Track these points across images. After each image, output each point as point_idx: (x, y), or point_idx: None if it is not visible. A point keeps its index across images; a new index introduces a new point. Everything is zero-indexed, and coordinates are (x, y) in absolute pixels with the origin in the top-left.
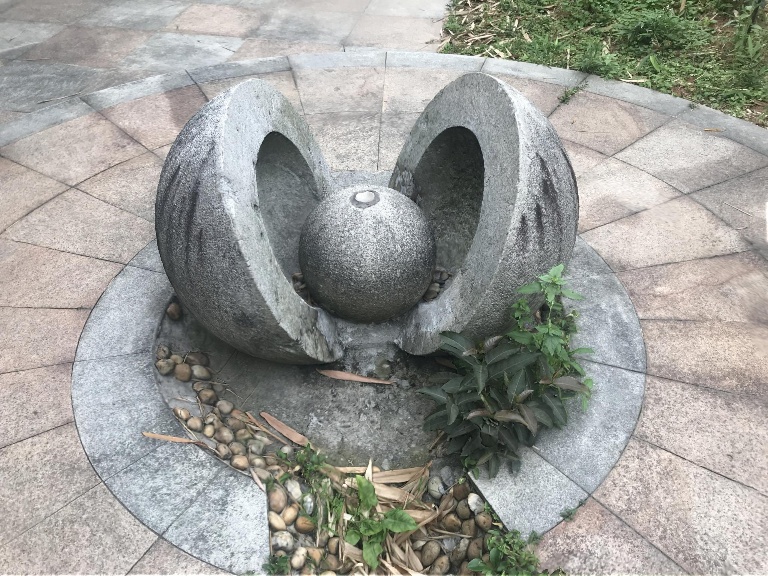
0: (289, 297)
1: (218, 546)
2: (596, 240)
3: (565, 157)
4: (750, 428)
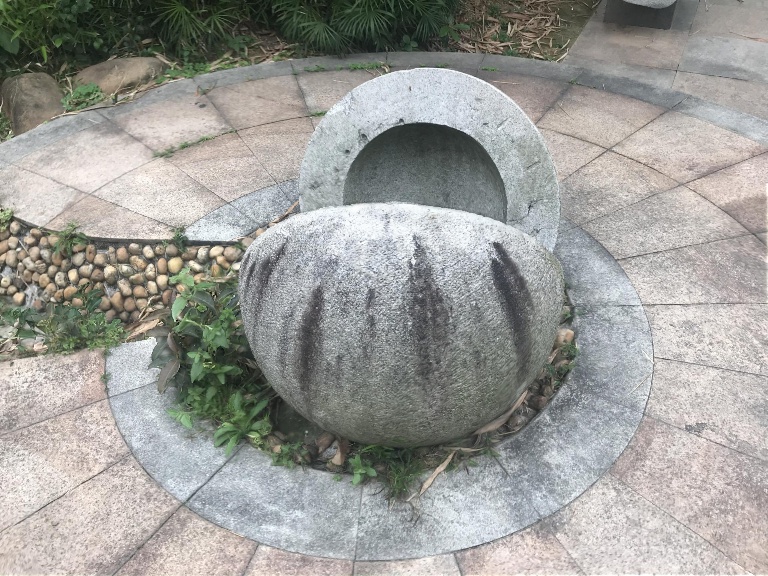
0: (331, 204)
1: (208, 222)
2: (434, 573)
3: (316, 296)
4: (63, 567)
